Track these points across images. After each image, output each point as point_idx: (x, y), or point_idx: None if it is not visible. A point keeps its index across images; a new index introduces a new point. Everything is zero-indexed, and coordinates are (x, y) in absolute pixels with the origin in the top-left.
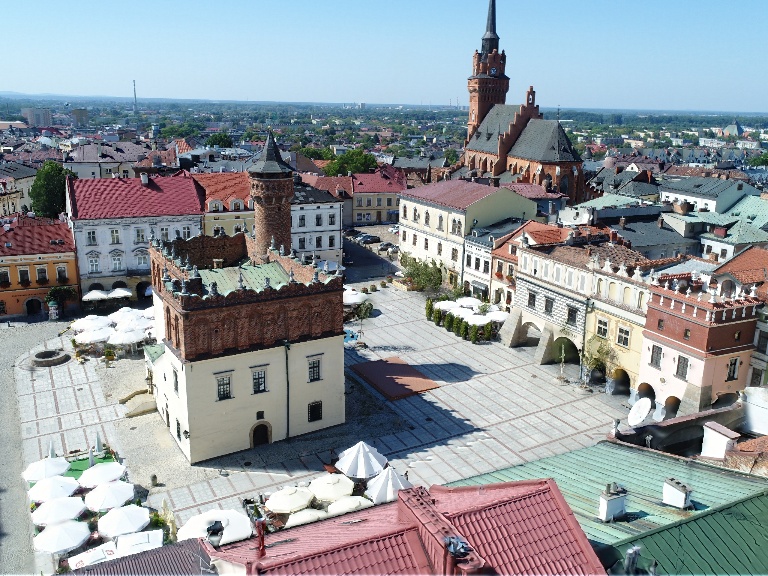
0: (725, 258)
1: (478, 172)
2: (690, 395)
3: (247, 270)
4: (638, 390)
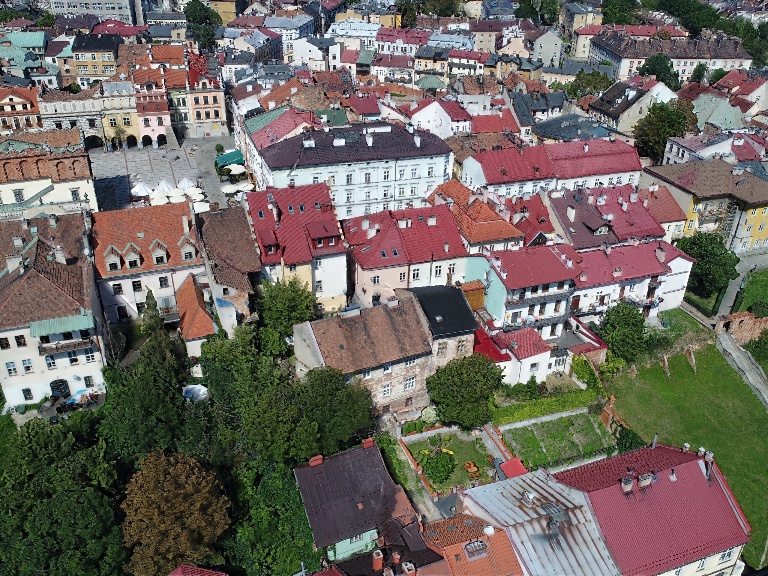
0: (52, 84)
1: None
2: (169, 130)
3: (14, 147)
4: (142, 140)
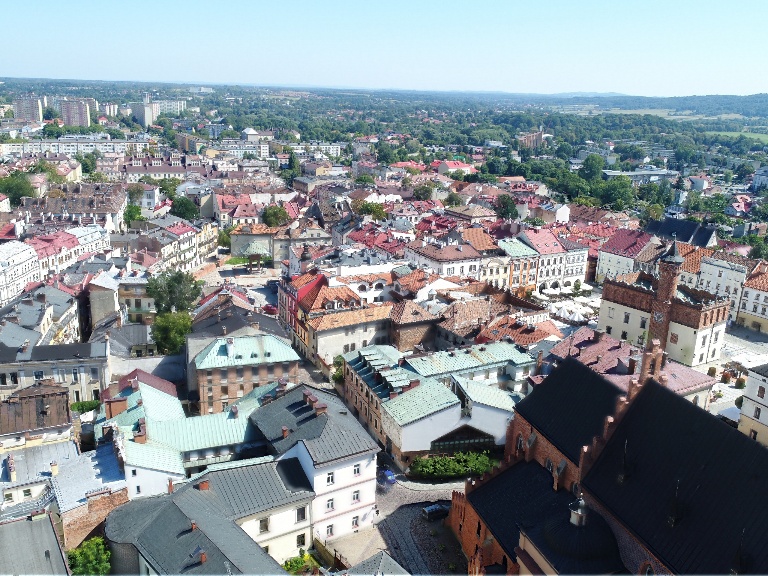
0: None
1: (637, 361)
2: None
3: None
4: None
